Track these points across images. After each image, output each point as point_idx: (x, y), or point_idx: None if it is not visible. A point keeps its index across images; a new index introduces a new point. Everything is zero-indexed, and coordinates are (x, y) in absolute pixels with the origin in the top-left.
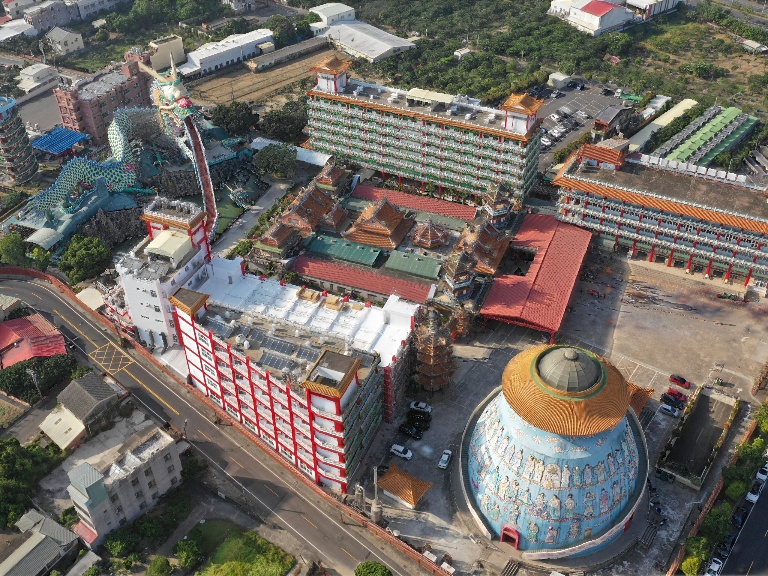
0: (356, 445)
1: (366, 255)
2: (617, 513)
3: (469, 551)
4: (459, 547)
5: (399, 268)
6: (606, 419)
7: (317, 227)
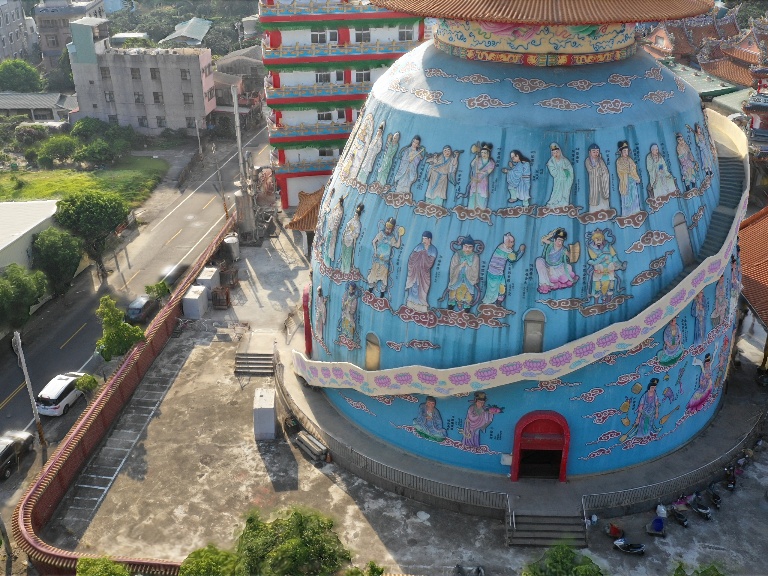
0: (316, 125)
1: (704, 85)
2: (462, 357)
3: (266, 317)
4: (266, 307)
5: (729, 103)
6: (494, 5)
7: (687, 59)
